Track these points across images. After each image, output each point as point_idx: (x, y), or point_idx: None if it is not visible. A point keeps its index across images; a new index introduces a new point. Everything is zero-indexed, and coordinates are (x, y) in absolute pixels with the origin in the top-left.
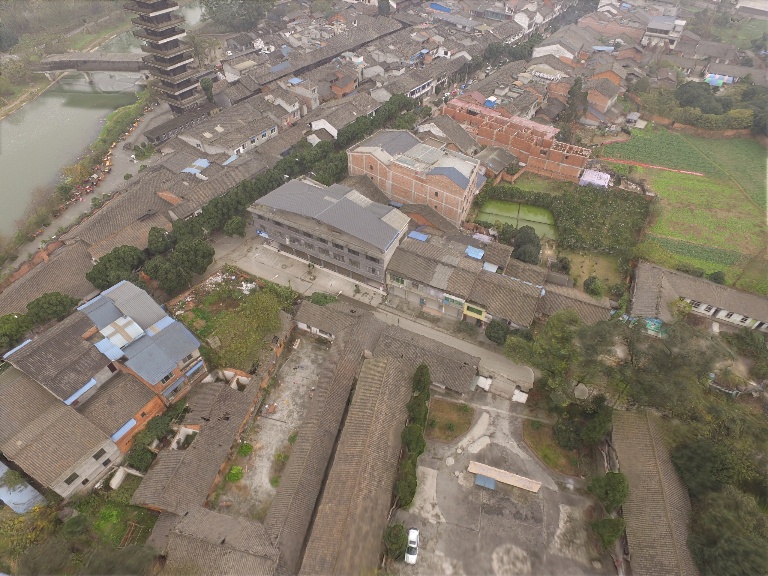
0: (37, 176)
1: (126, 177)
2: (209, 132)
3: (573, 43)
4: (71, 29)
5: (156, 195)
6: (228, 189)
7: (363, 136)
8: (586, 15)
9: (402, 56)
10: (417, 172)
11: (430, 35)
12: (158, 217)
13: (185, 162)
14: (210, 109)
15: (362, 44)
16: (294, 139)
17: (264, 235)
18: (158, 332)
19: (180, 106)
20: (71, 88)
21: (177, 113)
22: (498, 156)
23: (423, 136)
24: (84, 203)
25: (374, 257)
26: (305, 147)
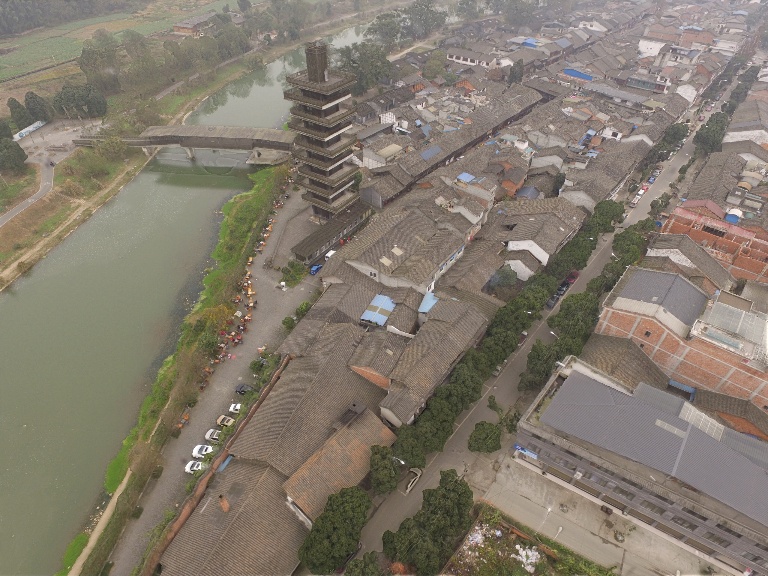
0: (154, 301)
1: (286, 322)
2: (387, 257)
3: None
4: (160, 89)
5: (349, 369)
6: (451, 364)
7: (584, 264)
8: (756, 87)
9: (569, 139)
10: (748, 360)
11: (593, 112)
12: (368, 417)
13: (362, 301)
14: (363, 212)
15: (506, 119)
16: (491, 265)
17: (529, 454)
18: None
19: (332, 211)
20: (172, 166)
21: (321, 215)
22: None
23: (663, 266)
24: (234, 362)
25: None
26: (511, 279)
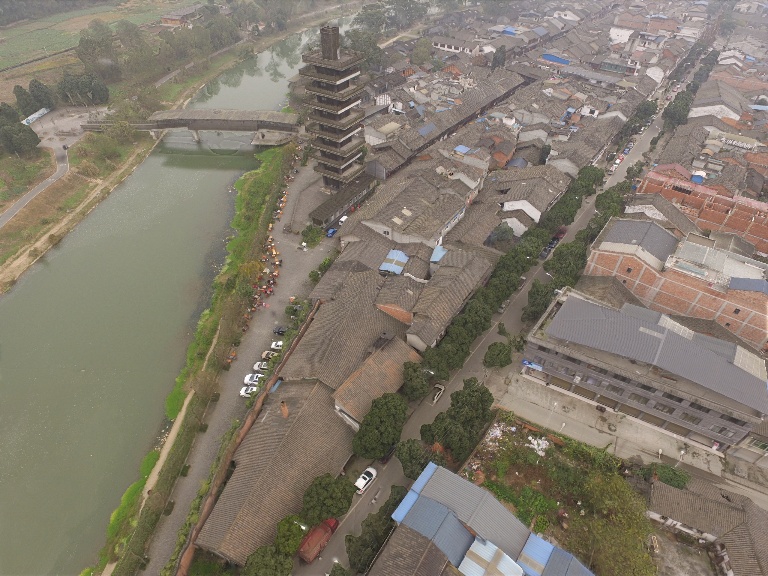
0: (184, 265)
1: (312, 275)
2: (398, 217)
3: (732, 102)
4: (157, 78)
5: (375, 307)
6: (464, 300)
7: (572, 220)
8: (717, 69)
9: (552, 116)
10: (712, 284)
11: (572, 92)
12: (398, 343)
13: (379, 255)
14: (370, 182)
15: (493, 100)
16: (491, 223)
17: (535, 367)
18: (544, 571)
19: (343, 180)
20: (180, 148)
21: None
22: (737, 246)
23: None
24: (269, 310)
25: (744, 421)
26: (509, 234)
